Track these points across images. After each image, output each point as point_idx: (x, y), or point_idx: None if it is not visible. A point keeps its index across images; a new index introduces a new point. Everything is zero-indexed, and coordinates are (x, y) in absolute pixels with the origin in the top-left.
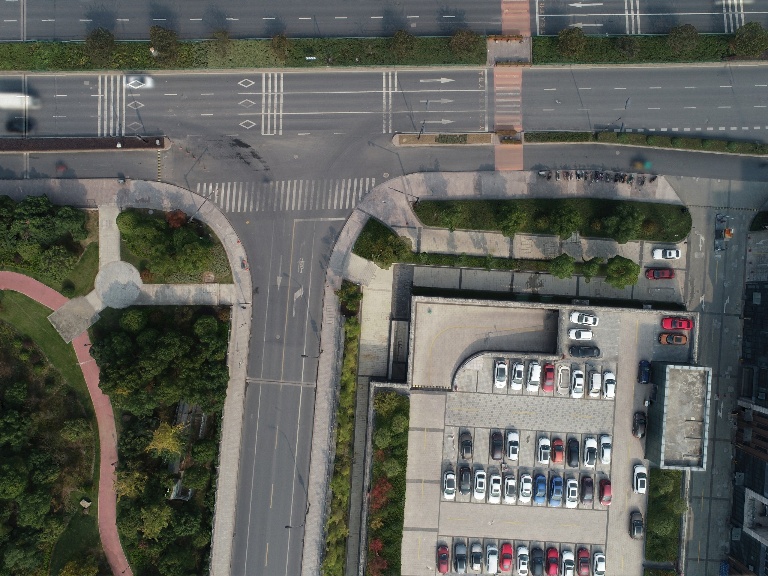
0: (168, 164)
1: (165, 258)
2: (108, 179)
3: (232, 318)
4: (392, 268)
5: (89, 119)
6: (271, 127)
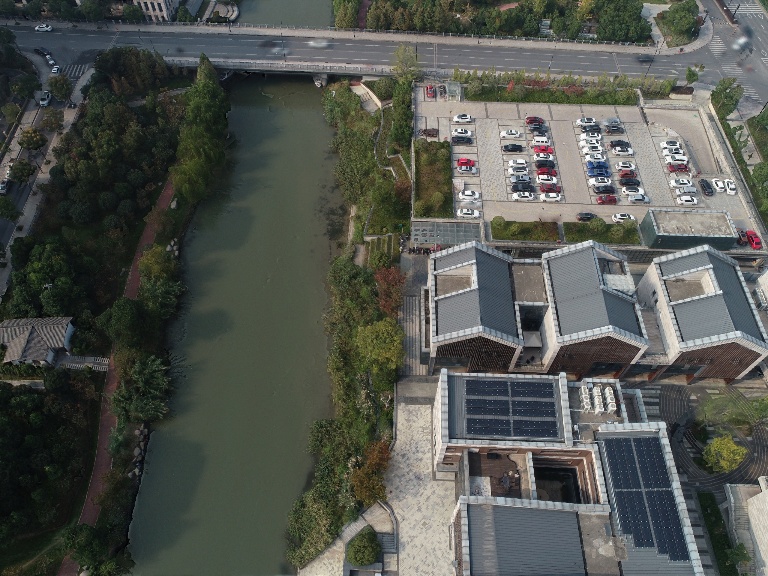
0: (724, 26)
1: (682, 8)
2: (704, 7)
3: (648, 47)
4: (708, 112)
5: (732, 2)
6: (767, 61)
